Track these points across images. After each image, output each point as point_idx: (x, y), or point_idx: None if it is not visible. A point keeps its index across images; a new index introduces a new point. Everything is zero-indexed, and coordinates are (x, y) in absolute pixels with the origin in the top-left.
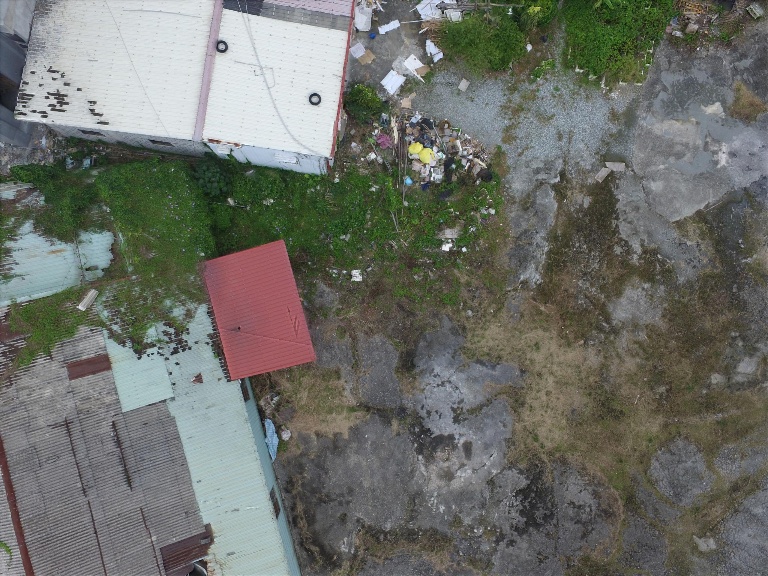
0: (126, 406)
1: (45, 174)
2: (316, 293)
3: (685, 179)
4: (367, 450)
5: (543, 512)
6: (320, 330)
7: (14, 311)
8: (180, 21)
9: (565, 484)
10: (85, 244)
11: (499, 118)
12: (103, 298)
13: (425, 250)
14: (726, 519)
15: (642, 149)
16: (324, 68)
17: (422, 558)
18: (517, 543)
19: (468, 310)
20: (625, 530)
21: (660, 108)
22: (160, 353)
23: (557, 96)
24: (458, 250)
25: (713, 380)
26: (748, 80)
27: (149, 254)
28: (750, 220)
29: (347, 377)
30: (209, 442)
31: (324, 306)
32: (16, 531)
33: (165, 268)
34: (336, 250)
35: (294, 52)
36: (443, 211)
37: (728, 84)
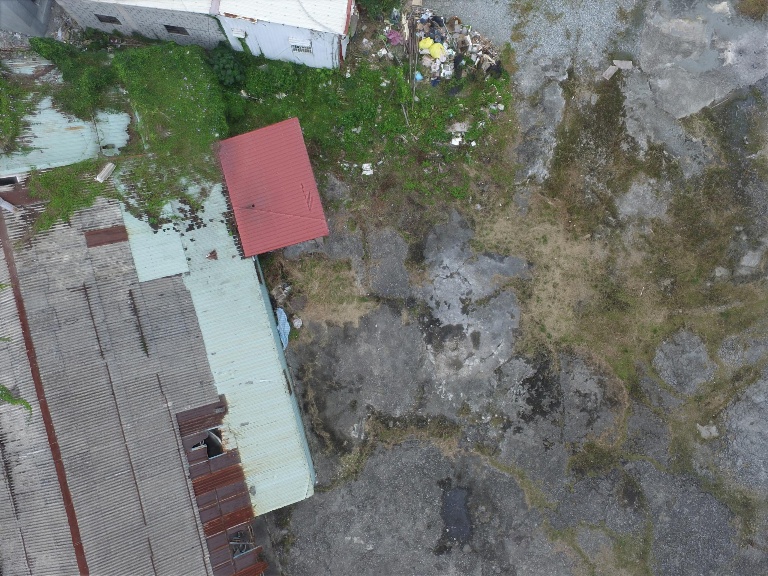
0: (143, 277)
1: (63, 50)
2: (327, 186)
3: (691, 77)
4: (377, 339)
5: (549, 400)
6: (331, 222)
7: (34, 177)
8: None
9: (571, 373)
10: (102, 123)
11: (508, 16)
12: (120, 172)
13: (435, 143)
14: (729, 408)
15: (649, 47)
16: None
17: (430, 444)
18: (524, 430)
19: (477, 204)
20: (630, 418)
21: (667, 7)
22: (176, 229)
23: None
24: (467, 144)
25: (717, 273)
26: None
27: (165, 133)
28: (755, 117)
29: (358, 268)
30: (223, 316)
31: (335, 199)
32: (36, 386)
33: (181, 147)
34: (347, 143)
35: None
36: (453, 106)
37: None
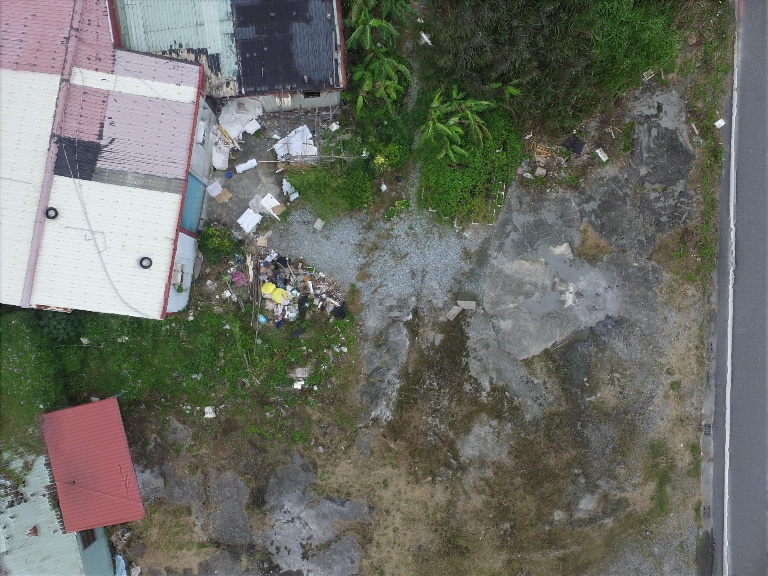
0: None
1: None
2: (169, 429)
3: (533, 318)
4: None
5: None
6: (173, 466)
7: None
8: (11, 187)
9: None
10: None
11: (353, 256)
12: None
13: (276, 389)
14: None
15: (492, 288)
16: (156, 231)
17: None
18: None
19: (319, 446)
20: None
21: (511, 248)
22: None
23: (411, 235)
24: (310, 388)
25: (556, 517)
26: (596, 221)
27: None
28: (595, 359)
29: (198, 513)
30: None
31: (177, 442)
32: None
33: (1, 422)
34: (189, 388)
35: (126, 216)
36: (296, 349)
37: (577, 225)
